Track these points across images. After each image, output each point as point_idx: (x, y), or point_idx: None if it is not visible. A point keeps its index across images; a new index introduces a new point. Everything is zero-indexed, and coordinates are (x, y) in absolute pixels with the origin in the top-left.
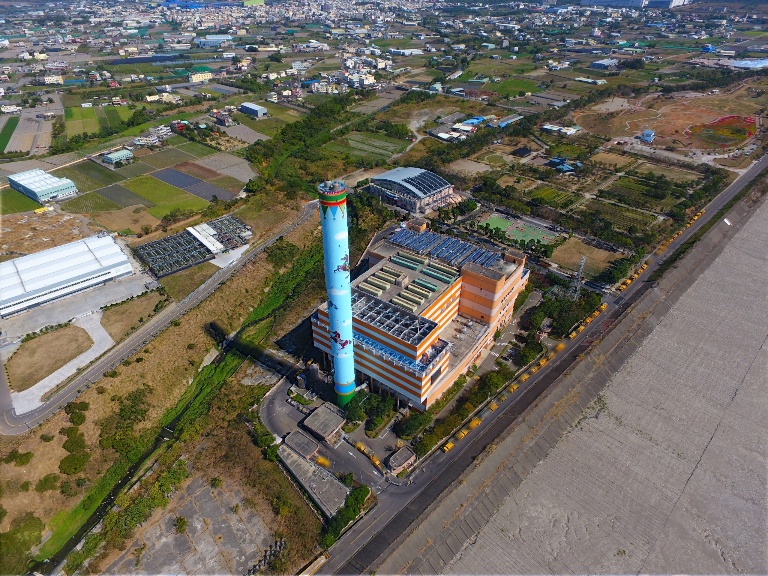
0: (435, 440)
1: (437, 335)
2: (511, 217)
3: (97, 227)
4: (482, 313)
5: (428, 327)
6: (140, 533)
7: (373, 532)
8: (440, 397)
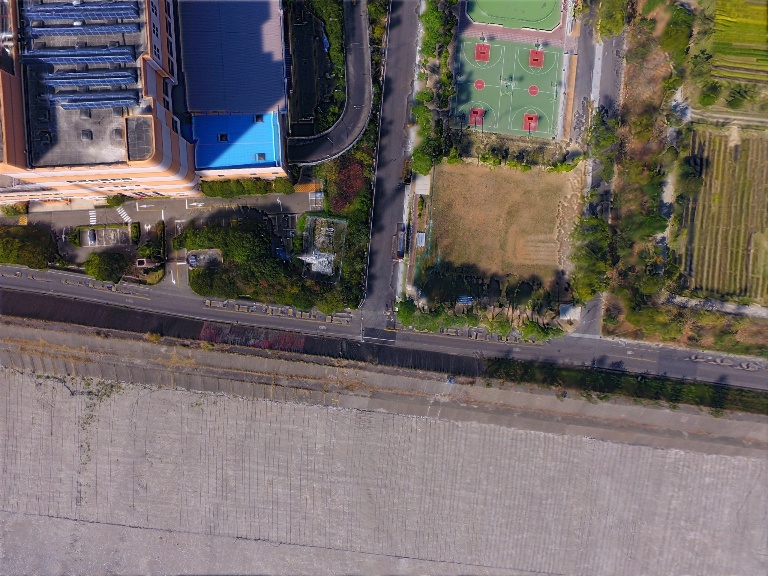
0: None
1: None
2: (579, 8)
3: None
4: None
5: None
6: None
7: None
8: None
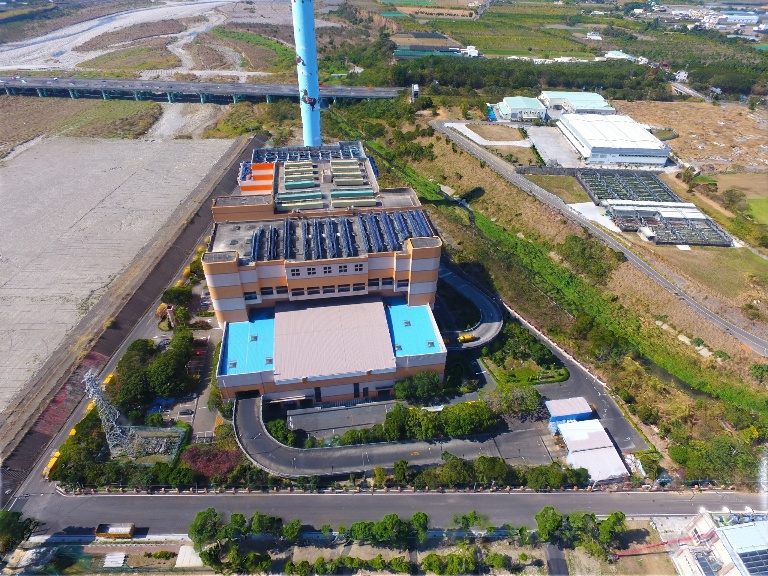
0: None
1: None
2: None
3: (729, 169)
4: None
5: None
6: None
7: None
8: None
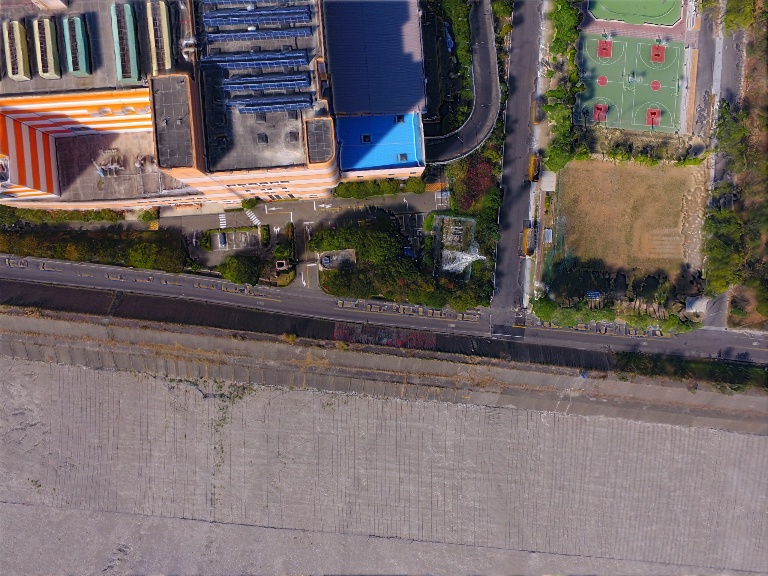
0: None
1: None
2: (700, 3)
3: None
4: None
5: None
6: None
7: None
8: (56, 209)
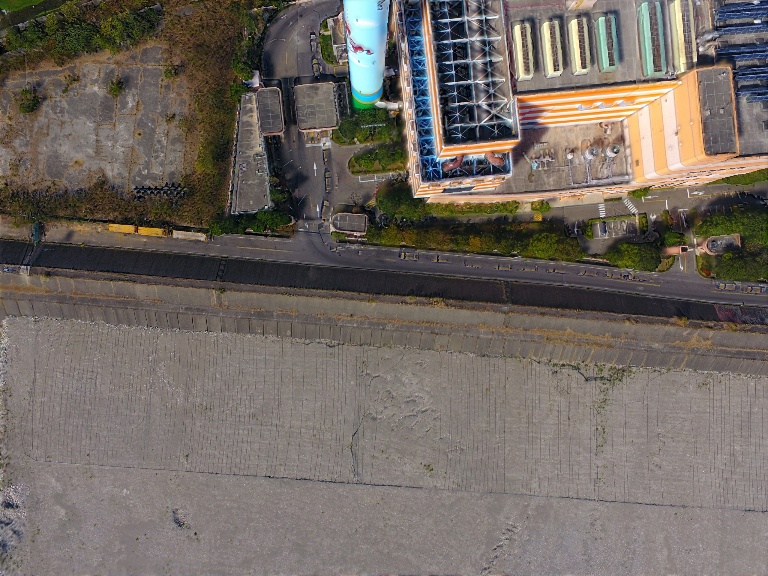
0: (396, 241)
1: (508, 148)
2: None
3: None
4: (642, 159)
5: (505, 127)
6: (80, 61)
7: (263, 257)
8: (460, 202)
